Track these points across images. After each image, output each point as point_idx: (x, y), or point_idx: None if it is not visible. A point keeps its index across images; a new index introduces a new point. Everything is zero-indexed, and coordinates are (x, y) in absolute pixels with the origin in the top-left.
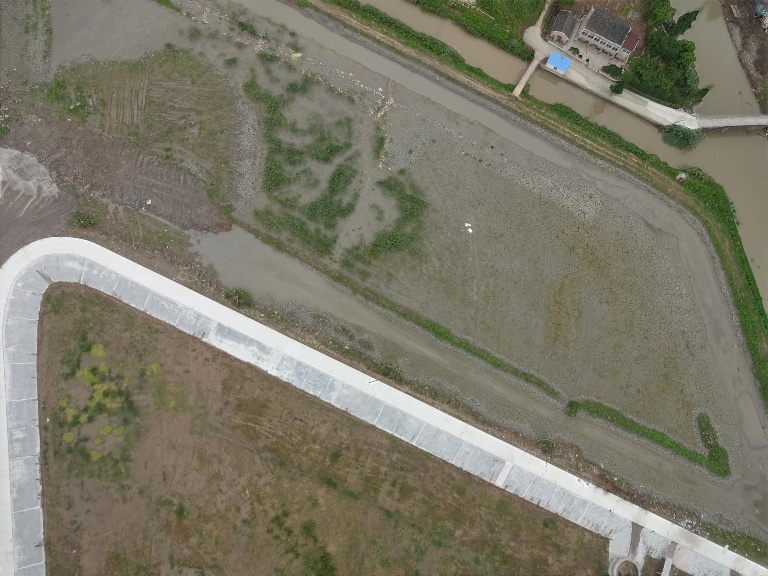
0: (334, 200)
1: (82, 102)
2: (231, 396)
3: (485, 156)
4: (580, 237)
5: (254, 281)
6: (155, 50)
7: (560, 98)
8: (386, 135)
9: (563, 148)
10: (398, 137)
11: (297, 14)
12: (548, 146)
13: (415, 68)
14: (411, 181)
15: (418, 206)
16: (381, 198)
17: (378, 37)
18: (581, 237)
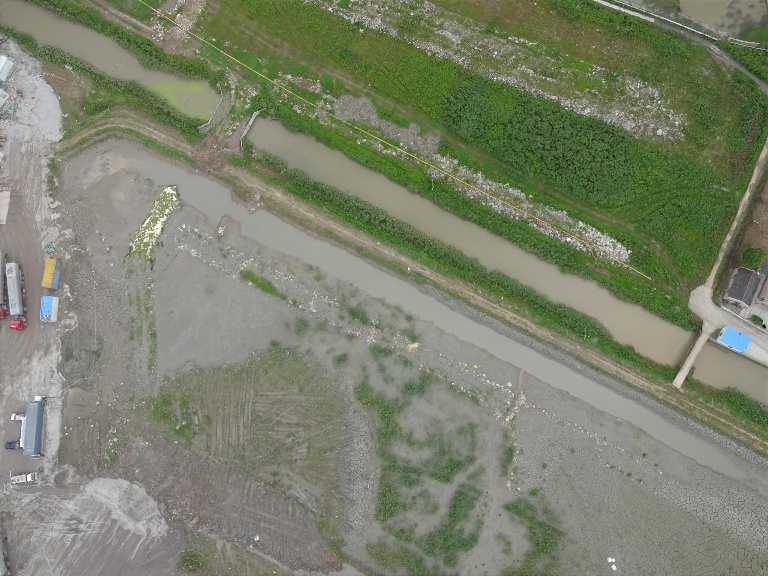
0: (455, 531)
1: (188, 421)
2: None
3: (635, 468)
4: (753, 575)
5: None
6: (261, 351)
7: (733, 380)
8: (515, 445)
9: (735, 453)
10: (530, 447)
11: (414, 290)
12: (715, 450)
13: (552, 355)
14: (544, 505)
15: (552, 539)
16: (508, 525)
17: (508, 317)
18: (754, 575)
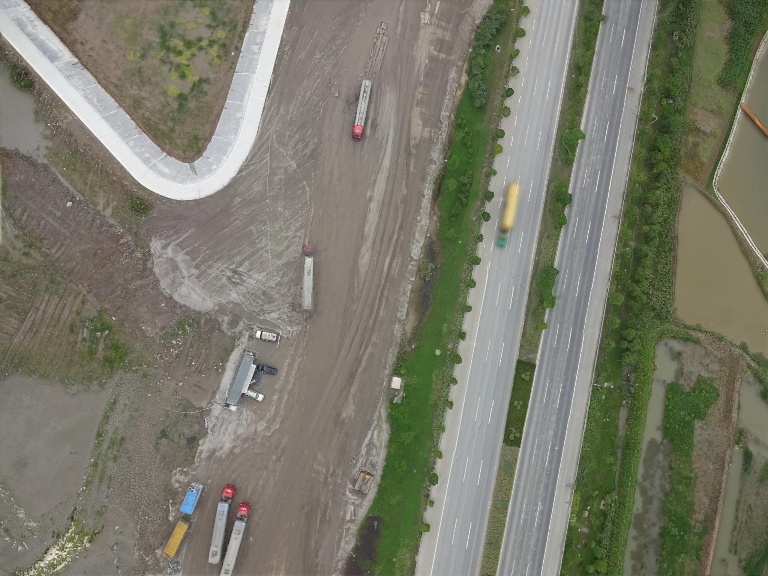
0: None
1: (94, 335)
2: (75, 5)
3: None
4: None
5: (2, 90)
6: None
7: None
8: None
9: None
10: None
11: None
12: None
13: None
14: None
15: None
16: None
17: None
18: None
